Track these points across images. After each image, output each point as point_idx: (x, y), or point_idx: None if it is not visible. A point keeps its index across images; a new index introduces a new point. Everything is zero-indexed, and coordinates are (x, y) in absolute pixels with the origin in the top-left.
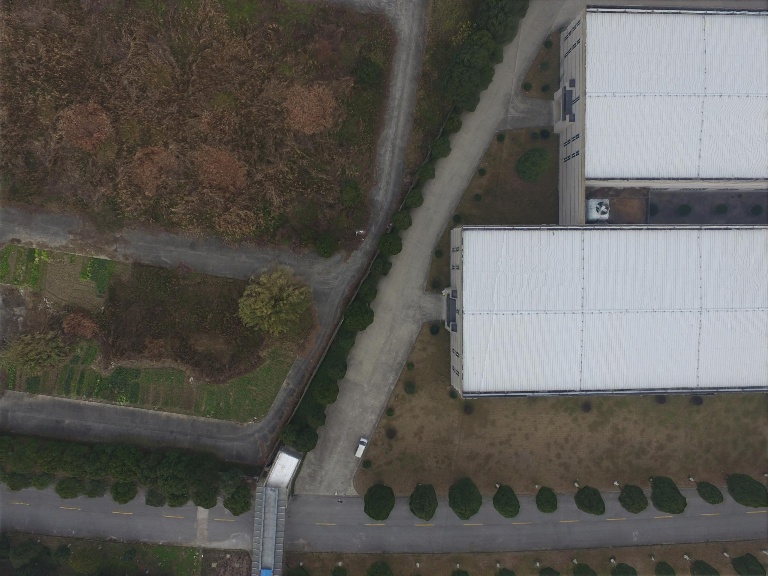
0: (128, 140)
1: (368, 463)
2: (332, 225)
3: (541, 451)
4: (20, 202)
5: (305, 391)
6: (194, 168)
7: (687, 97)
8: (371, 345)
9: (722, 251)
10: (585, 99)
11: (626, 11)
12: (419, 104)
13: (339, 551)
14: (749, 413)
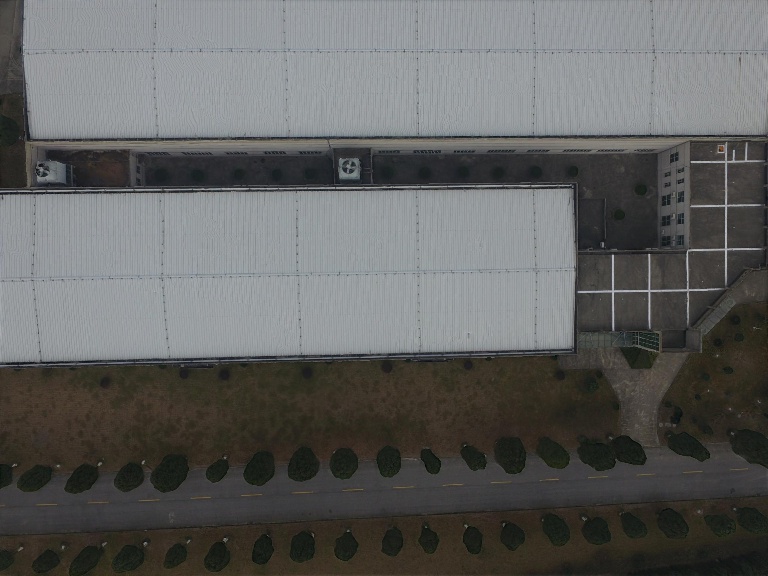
0: None
1: None
2: None
3: (61, 429)
4: None
5: None
6: None
7: (135, 53)
8: None
9: (187, 215)
10: (22, 56)
11: None
12: None
13: None
14: (285, 388)
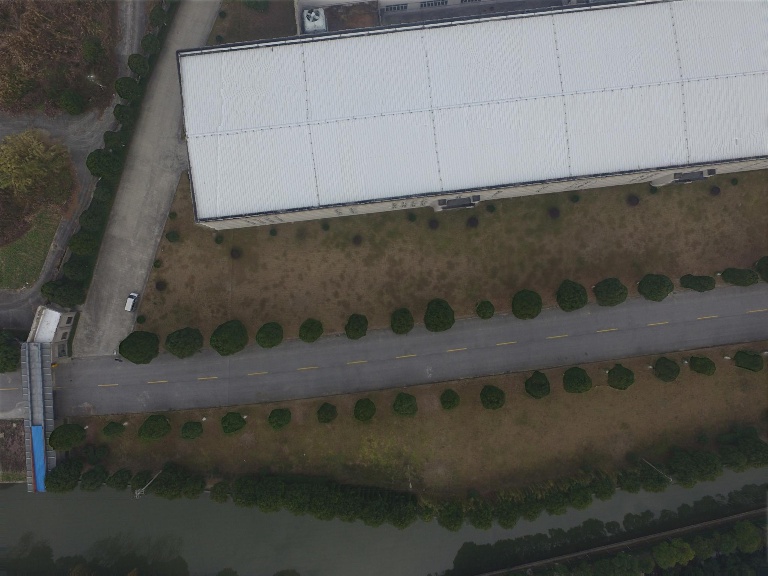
0: None
1: (141, 317)
2: (77, 82)
3: (317, 291)
4: None
5: (68, 249)
6: None
7: None
8: (133, 199)
9: (449, 48)
10: None
11: None
12: None
13: (125, 412)
14: (533, 232)
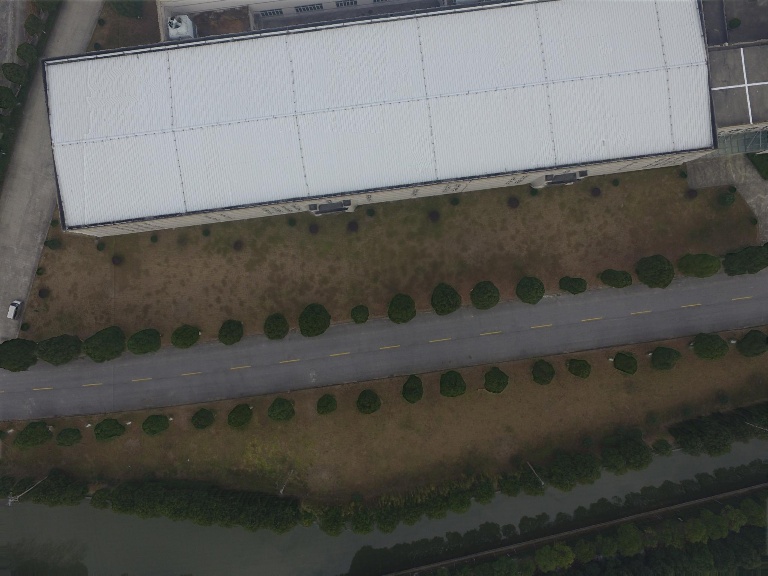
0: None
1: (24, 325)
2: None
3: (200, 297)
4: None
5: None
6: None
7: None
8: (16, 207)
9: (313, 53)
10: None
11: None
12: None
13: (11, 419)
14: (414, 235)
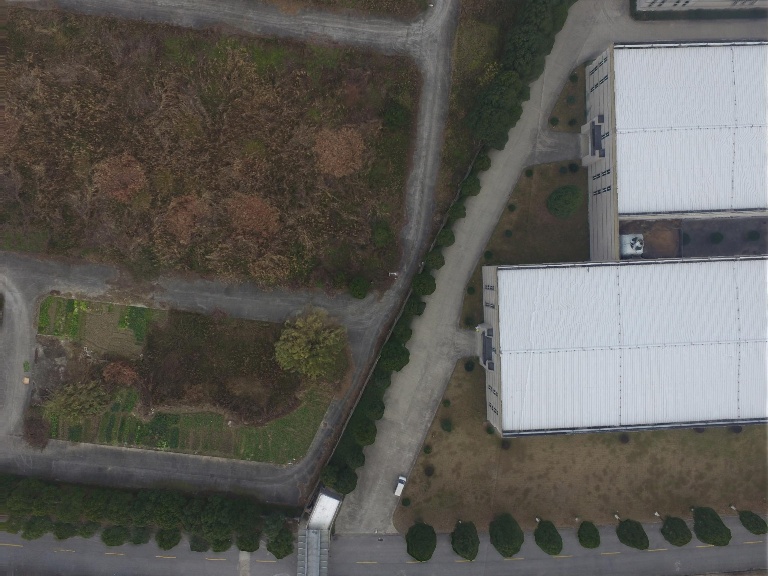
0: (162, 190)
1: (407, 501)
2: (365, 266)
3: (580, 484)
4: (59, 255)
5: (343, 432)
6: (227, 215)
7: (718, 129)
8: (406, 383)
9: (759, 281)
10: (615, 136)
11: (653, 46)
12: (447, 143)
13: None
14: None
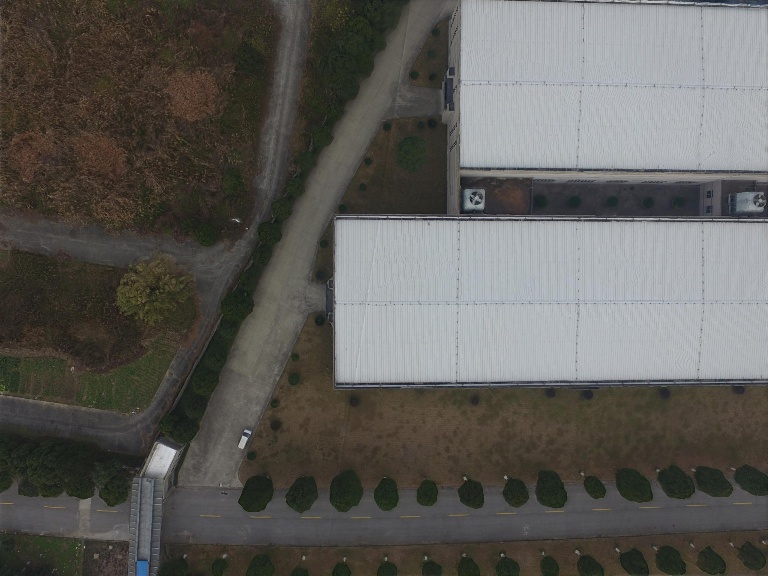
0: (6, 125)
1: (252, 455)
2: (213, 213)
3: (429, 444)
4: None
5: (186, 381)
6: (73, 154)
7: (564, 86)
8: (256, 336)
9: (601, 243)
10: (459, 87)
11: None
12: (304, 92)
13: (224, 543)
14: (641, 408)
